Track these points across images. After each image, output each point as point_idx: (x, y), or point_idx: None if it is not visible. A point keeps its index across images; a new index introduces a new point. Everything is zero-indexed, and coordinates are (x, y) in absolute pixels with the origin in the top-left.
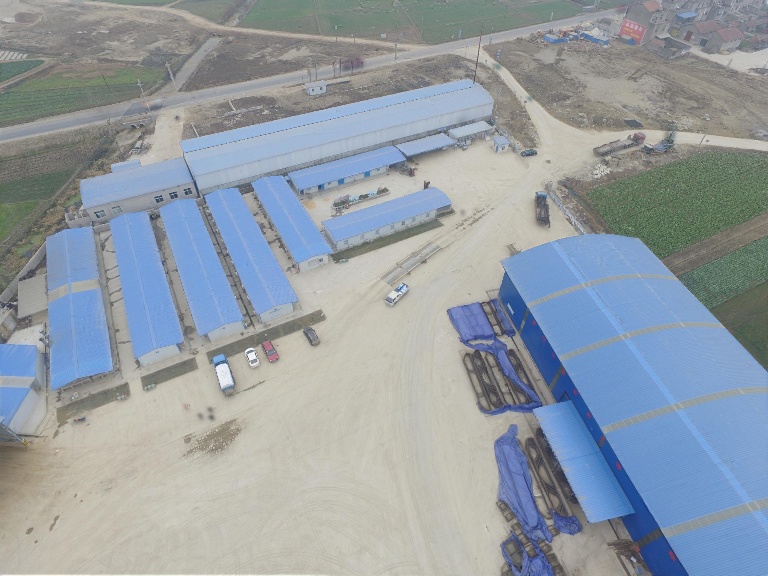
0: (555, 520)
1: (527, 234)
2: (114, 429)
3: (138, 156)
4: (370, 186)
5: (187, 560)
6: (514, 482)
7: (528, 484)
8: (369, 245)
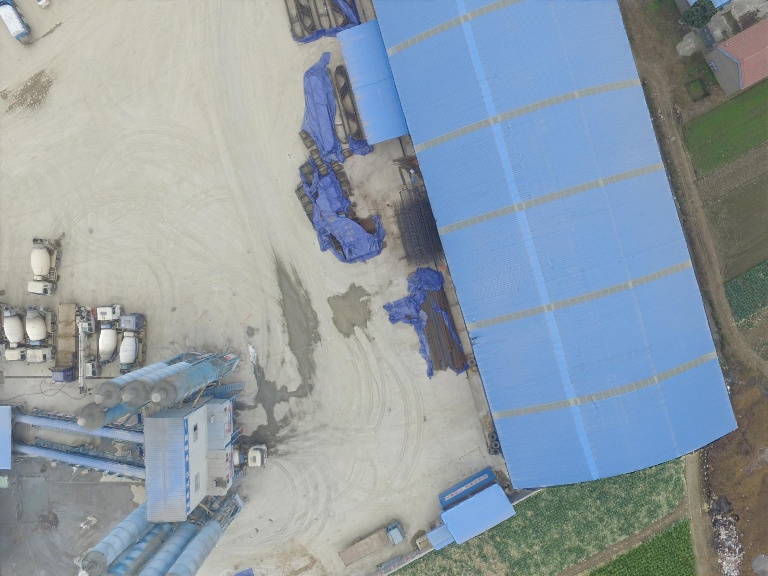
0: (350, 144)
1: None
2: None
3: None
4: None
5: (40, 197)
6: (317, 113)
7: (330, 113)
8: None
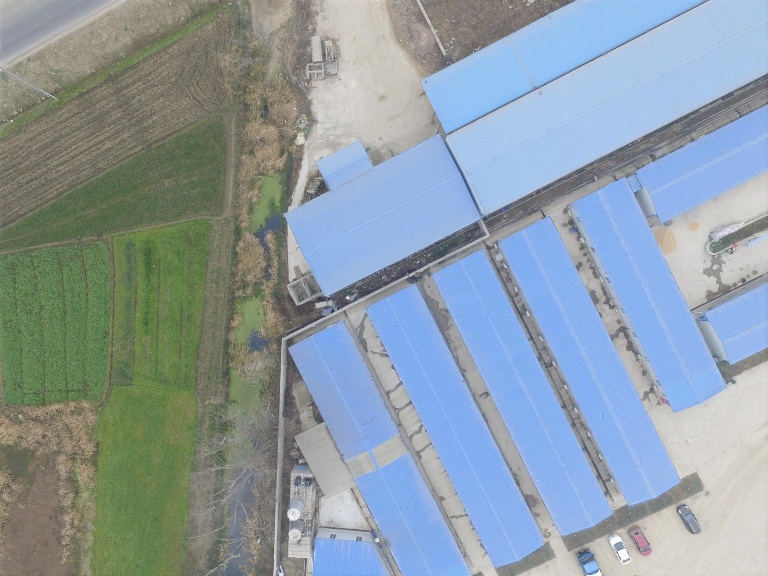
0: None
1: None
2: None
3: (326, 85)
4: None
5: None
6: None
7: None
8: None
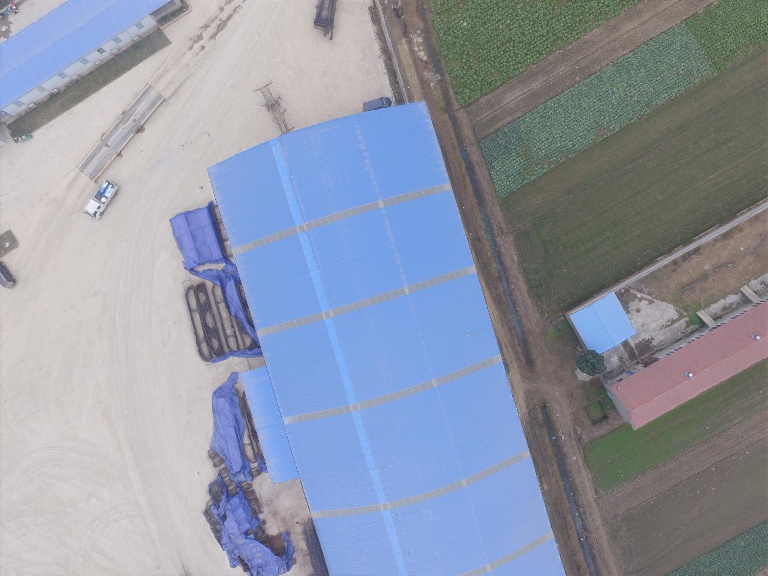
0: (259, 463)
1: (298, 53)
2: None
3: None
4: None
5: None
6: (225, 434)
7: (238, 435)
8: (60, 99)
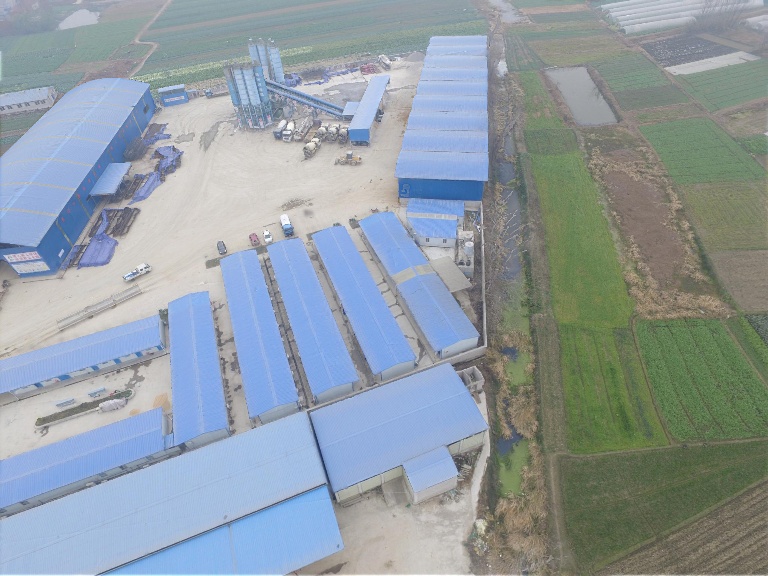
0: None
1: None
2: (354, 209)
3: None
4: (54, 440)
5: None
6: (150, 185)
7: None
8: None
